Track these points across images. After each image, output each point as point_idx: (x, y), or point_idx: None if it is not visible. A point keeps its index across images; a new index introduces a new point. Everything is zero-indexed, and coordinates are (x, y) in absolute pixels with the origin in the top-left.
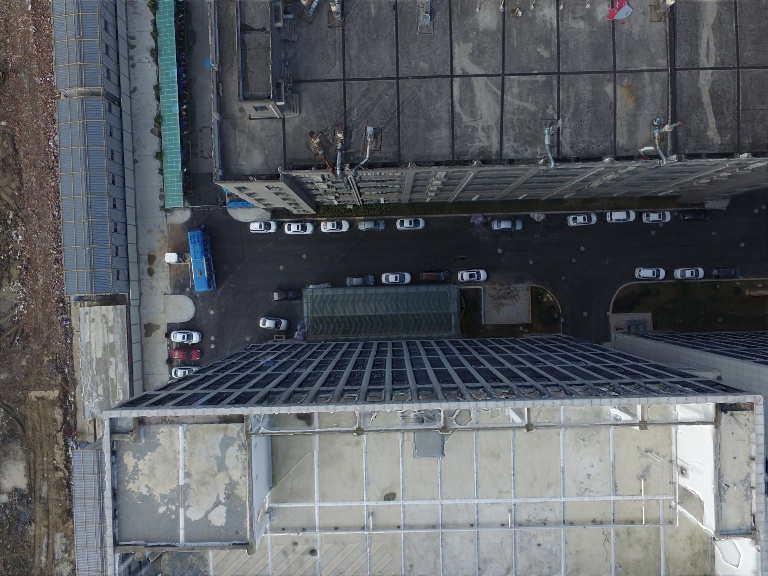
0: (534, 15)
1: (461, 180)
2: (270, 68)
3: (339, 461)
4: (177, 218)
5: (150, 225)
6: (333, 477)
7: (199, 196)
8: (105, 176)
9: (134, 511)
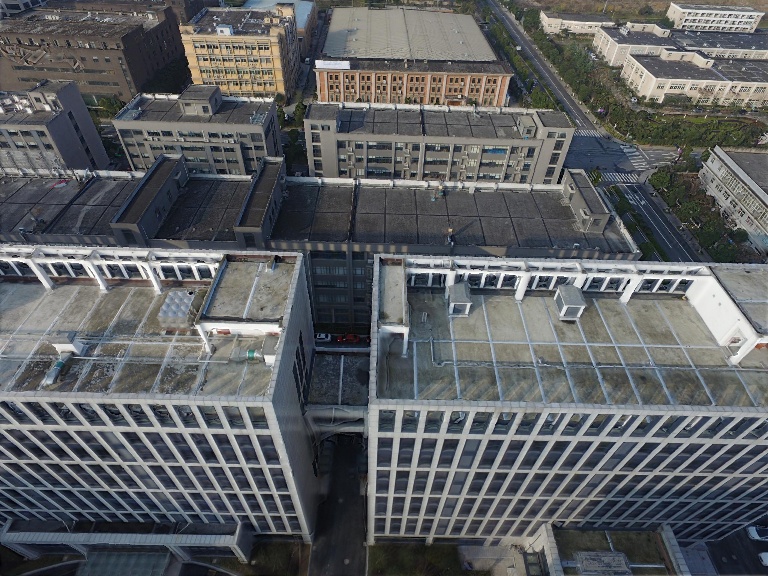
0: (12, 184)
1: None
2: None
3: None
4: None
5: None
6: None
7: None
8: None
9: None
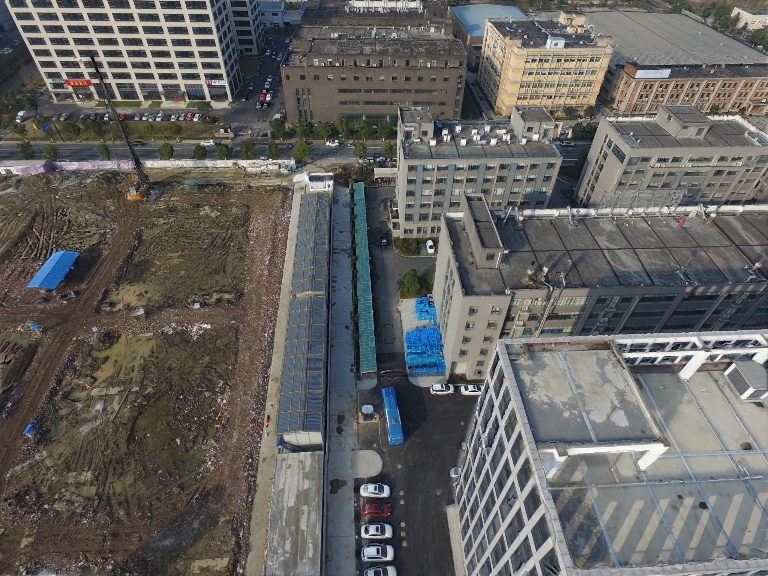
0: (635, 226)
1: (621, 318)
2: (498, 235)
3: (681, 416)
4: (365, 385)
5: (341, 391)
6: (683, 430)
7: (384, 369)
8: (323, 342)
9: (541, 416)
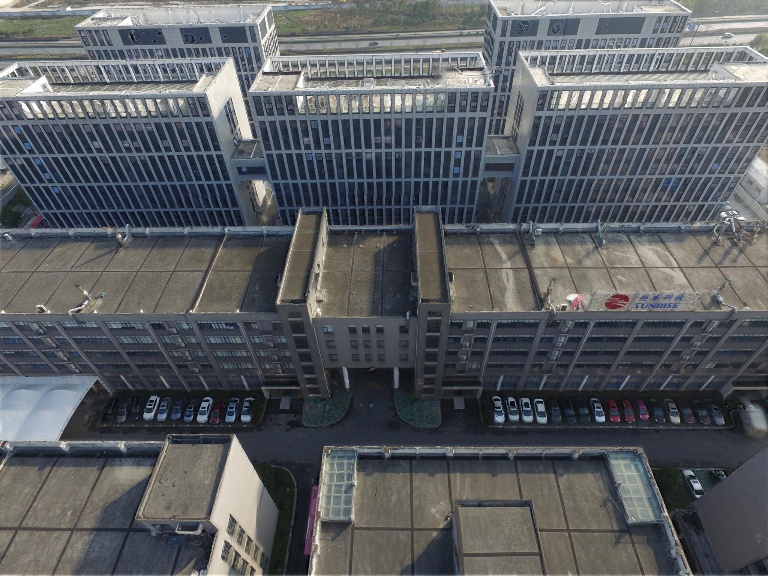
0: None
1: None
2: None
3: None
4: None
5: None
6: None
7: None
8: None
9: None
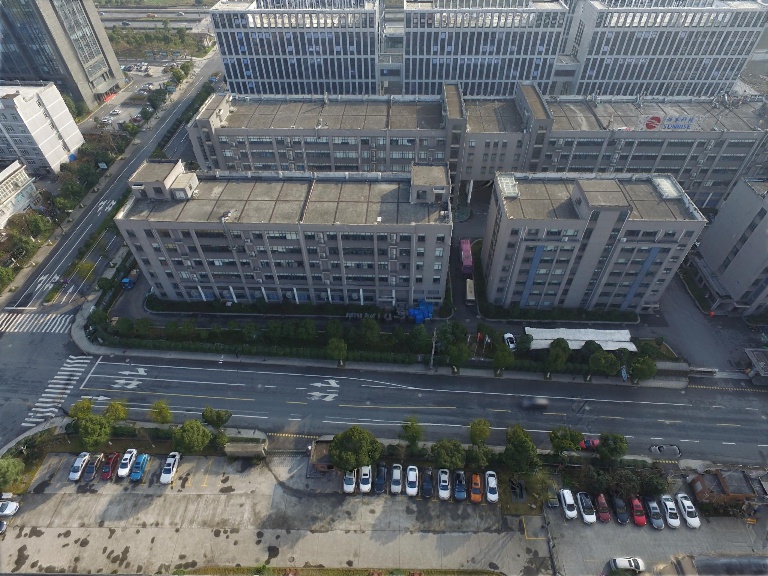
0: None
1: None
2: None
3: None
4: None
5: None
6: None
7: None
8: None
9: None
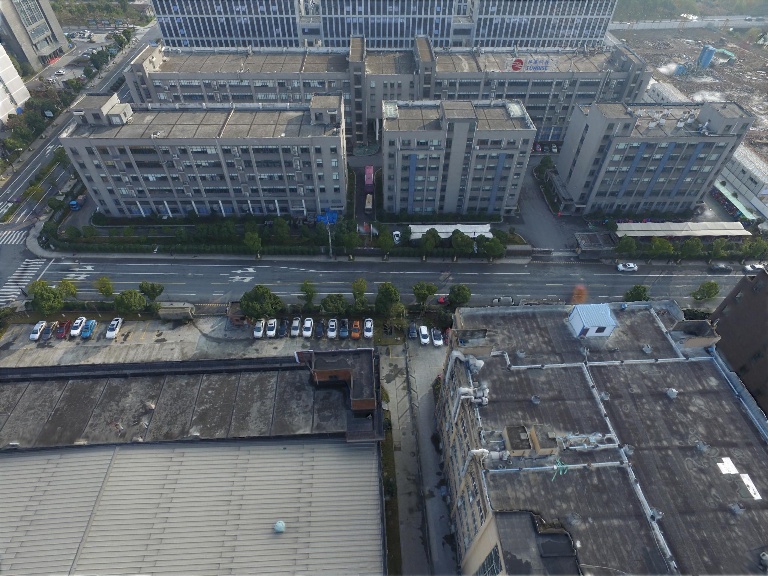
0: None
1: None
2: None
3: None
4: None
5: None
6: None
7: None
8: None
9: None
